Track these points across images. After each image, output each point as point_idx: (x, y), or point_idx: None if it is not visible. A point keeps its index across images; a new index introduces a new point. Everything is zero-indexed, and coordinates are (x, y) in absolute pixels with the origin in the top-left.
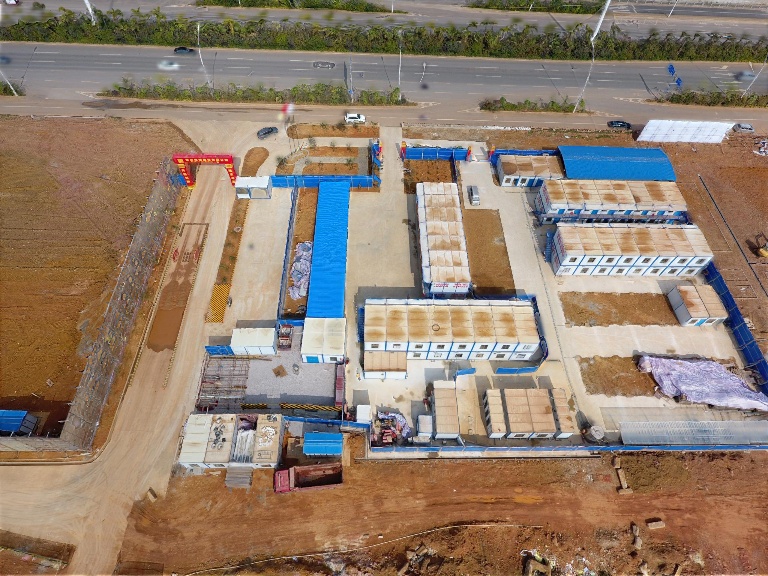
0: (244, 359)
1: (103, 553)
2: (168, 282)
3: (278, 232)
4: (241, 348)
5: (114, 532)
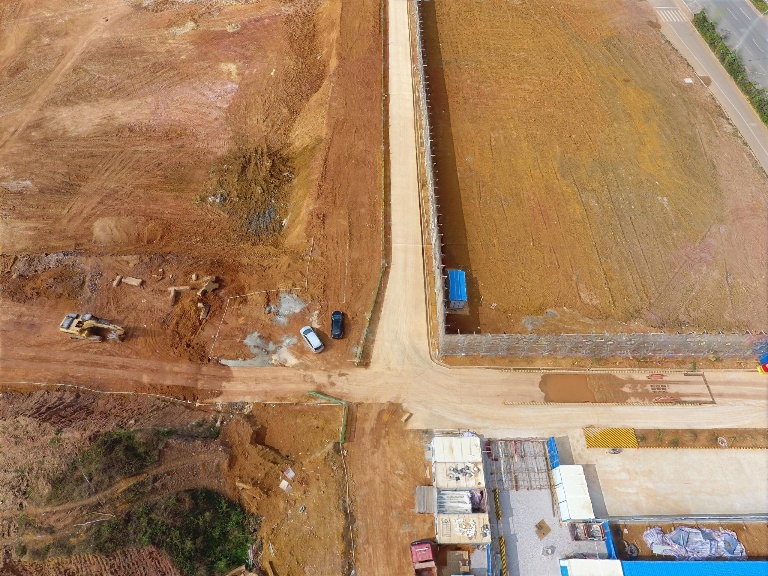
0: (549, 482)
1: (364, 390)
2: (620, 377)
3: (741, 499)
4: (560, 478)
5: (378, 394)
